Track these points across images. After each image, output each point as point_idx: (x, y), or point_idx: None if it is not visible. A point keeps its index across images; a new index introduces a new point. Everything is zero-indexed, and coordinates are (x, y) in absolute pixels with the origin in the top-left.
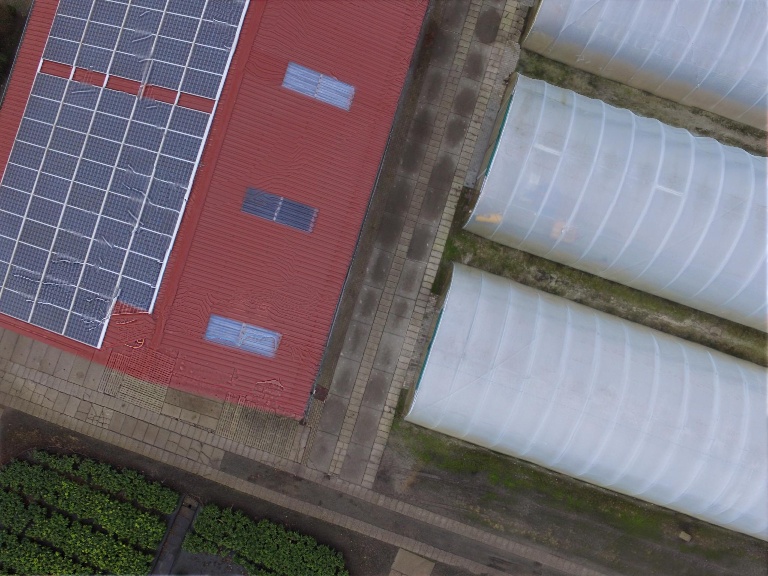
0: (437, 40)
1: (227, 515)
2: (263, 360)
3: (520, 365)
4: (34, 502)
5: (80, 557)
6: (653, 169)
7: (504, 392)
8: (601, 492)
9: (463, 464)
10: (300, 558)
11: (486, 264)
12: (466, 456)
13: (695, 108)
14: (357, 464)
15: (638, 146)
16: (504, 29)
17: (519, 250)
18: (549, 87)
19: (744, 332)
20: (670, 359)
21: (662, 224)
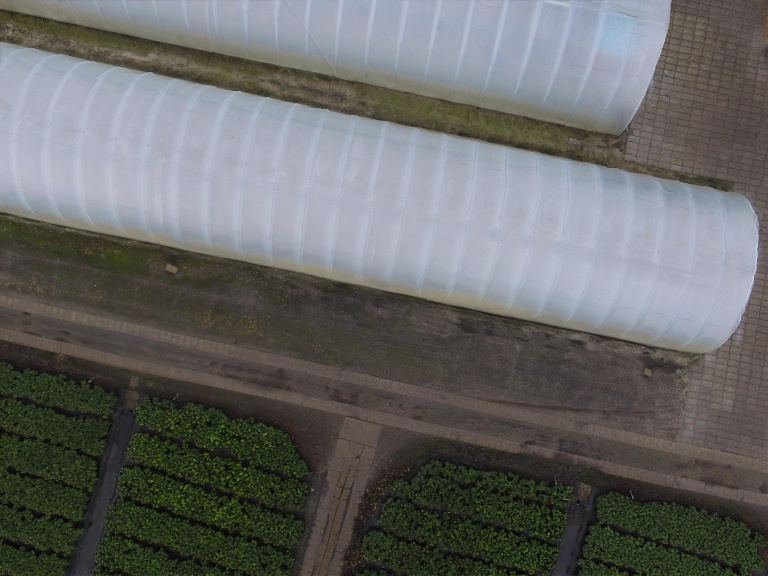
0: None
1: None
2: None
3: None
4: None
5: None
6: None
7: None
8: (82, 235)
9: None
10: None
11: None
12: None
13: None
14: None
15: None
16: None
17: None
18: None
19: (210, 59)
20: None
21: None
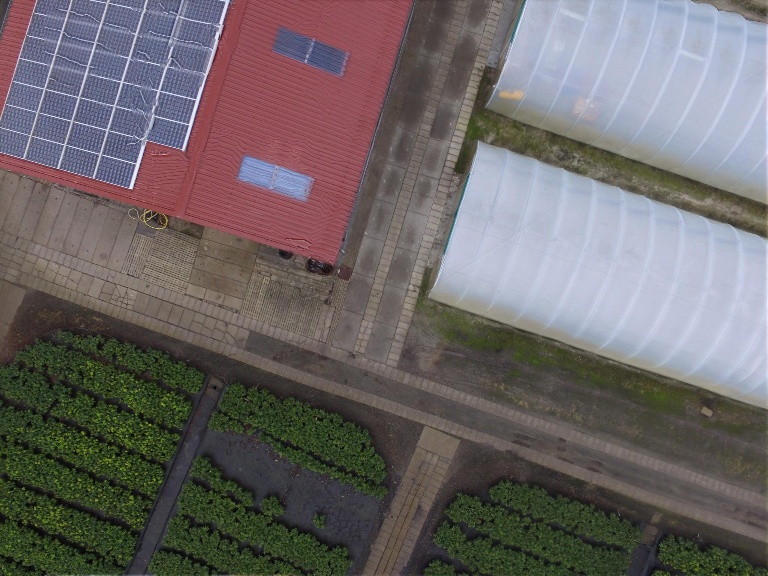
0: None
1: (253, 393)
2: (292, 219)
3: (547, 228)
4: (59, 382)
5: (106, 436)
6: (677, 34)
7: (531, 255)
8: (624, 369)
9: (487, 342)
10: (326, 435)
11: (509, 143)
12: (490, 334)
13: None
14: (382, 343)
15: (662, 12)
16: None
17: (542, 129)
18: None
19: (764, 210)
20: (693, 229)
21: (686, 89)
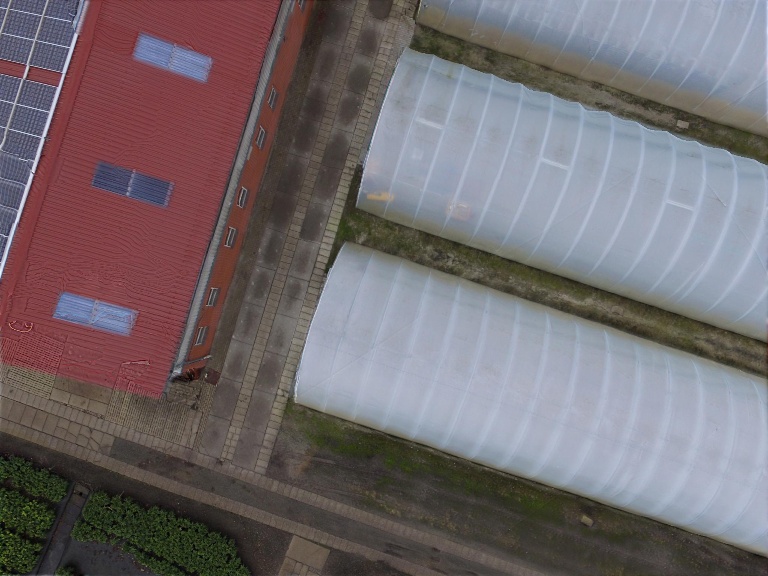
0: (329, 16)
1: (116, 502)
2: (133, 340)
3: (402, 344)
4: None
5: None
6: (538, 142)
7: (386, 372)
8: (500, 476)
9: (358, 448)
10: (191, 546)
11: (381, 244)
12: (361, 440)
13: (594, 83)
14: (250, 449)
15: (524, 119)
16: (398, 4)
17: (415, 229)
18: (437, 61)
19: (646, 311)
20: (563, 338)
21: (549, 198)
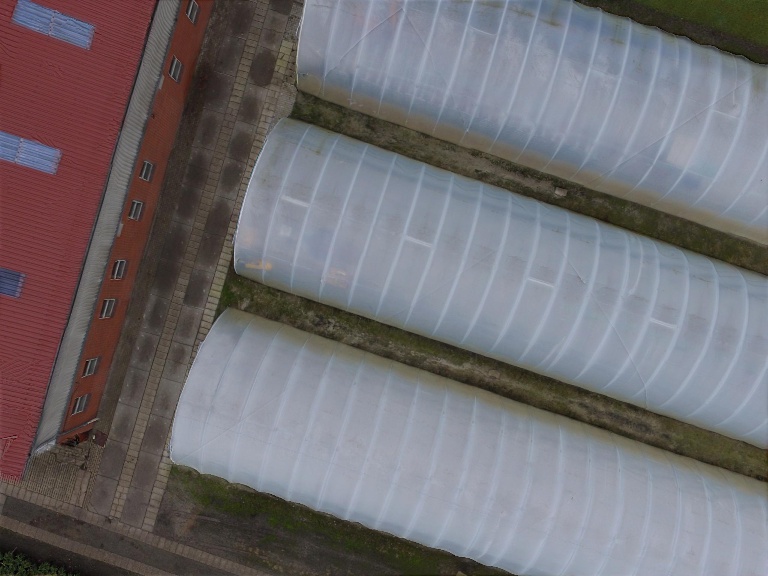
0: (211, 83)
1: (8, 559)
2: (3, 417)
3: (268, 417)
4: None
5: None
6: (402, 220)
7: (253, 444)
8: (379, 533)
9: (242, 507)
10: None
11: (263, 309)
12: (245, 499)
13: (474, 150)
14: (137, 508)
15: (390, 196)
16: (280, 71)
17: (296, 295)
18: (309, 134)
19: (522, 375)
20: (431, 407)
21: (413, 275)
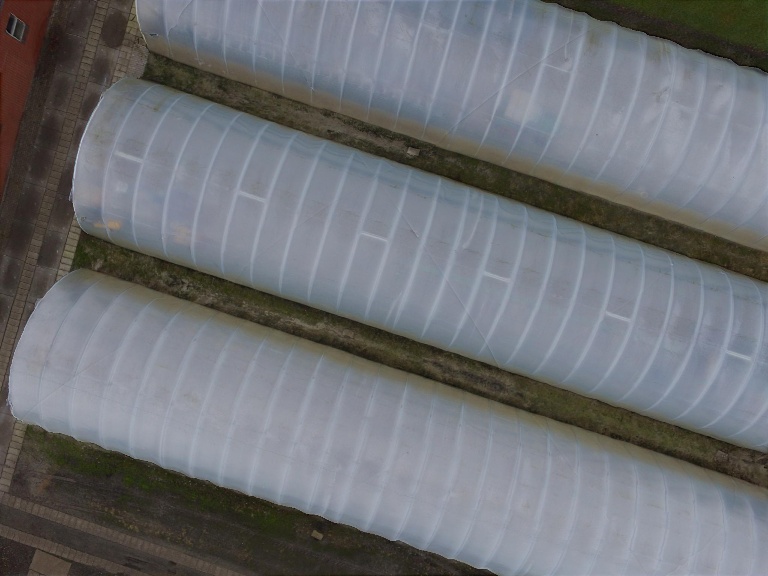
0: (62, 45)
1: None
2: None
3: (103, 372)
4: None
5: None
6: (236, 175)
7: (89, 399)
8: (234, 493)
9: (97, 467)
10: None
11: (117, 270)
12: (100, 459)
13: (326, 110)
14: None
15: (225, 152)
16: (131, 32)
17: (149, 256)
18: (150, 92)
19: (376, 334)
20: (275, 363)
21: (248, 230)
